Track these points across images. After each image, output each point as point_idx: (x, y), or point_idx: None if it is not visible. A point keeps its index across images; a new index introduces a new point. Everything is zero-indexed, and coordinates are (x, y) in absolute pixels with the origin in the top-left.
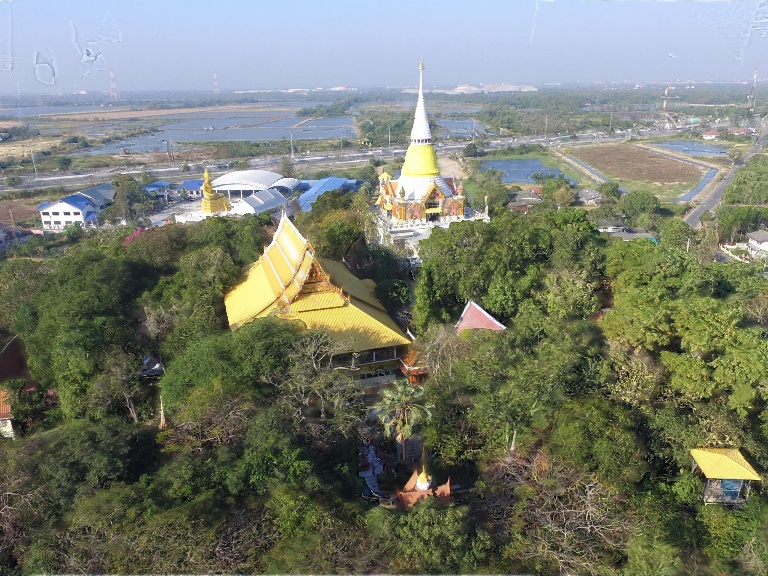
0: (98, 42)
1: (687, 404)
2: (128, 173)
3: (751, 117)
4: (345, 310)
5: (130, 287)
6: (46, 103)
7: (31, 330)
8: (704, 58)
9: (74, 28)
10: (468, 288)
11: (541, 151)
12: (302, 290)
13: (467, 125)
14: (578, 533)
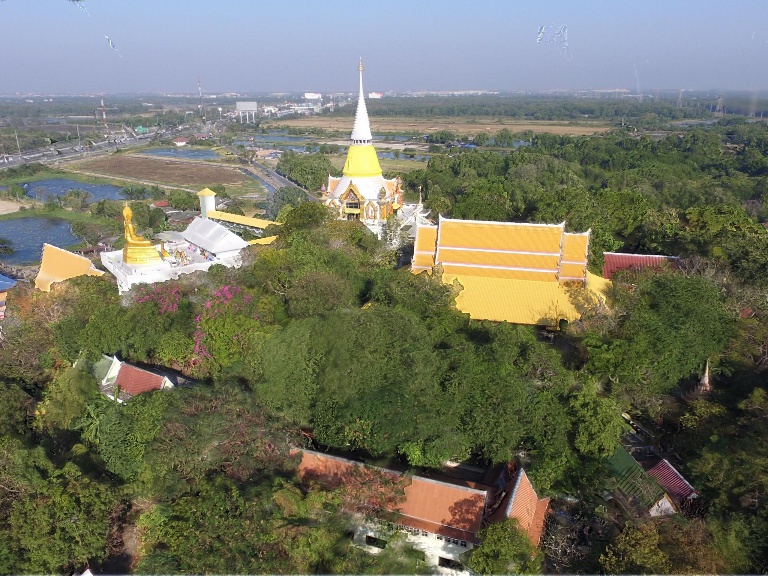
0: None
1: None
2: None
3: (205, 124)
4: (590, 276)
5: None
6: None
7: (416, 419)
8: None
9: None
10: None
11: (50, 169)
12: None
13: None
14: None
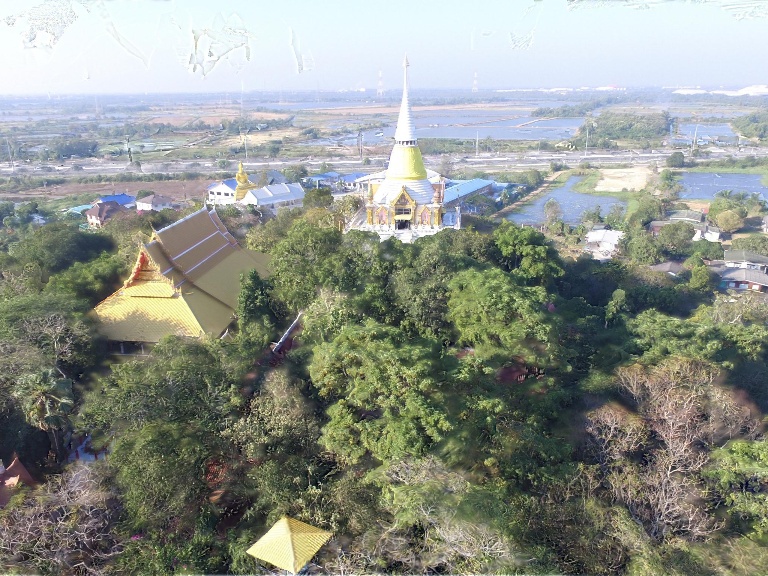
0: (222, 44)
1: (342, 467)
2: (320, 163)
3: None
4: (172, 301)
5: (72, 256)
6: (263, 98)
7: None
8: (135, 49)
9: (292, 32)
10: (291, 298)
11: None
12: (140, 276)
13: (688, 131)
14: (15, 557)
